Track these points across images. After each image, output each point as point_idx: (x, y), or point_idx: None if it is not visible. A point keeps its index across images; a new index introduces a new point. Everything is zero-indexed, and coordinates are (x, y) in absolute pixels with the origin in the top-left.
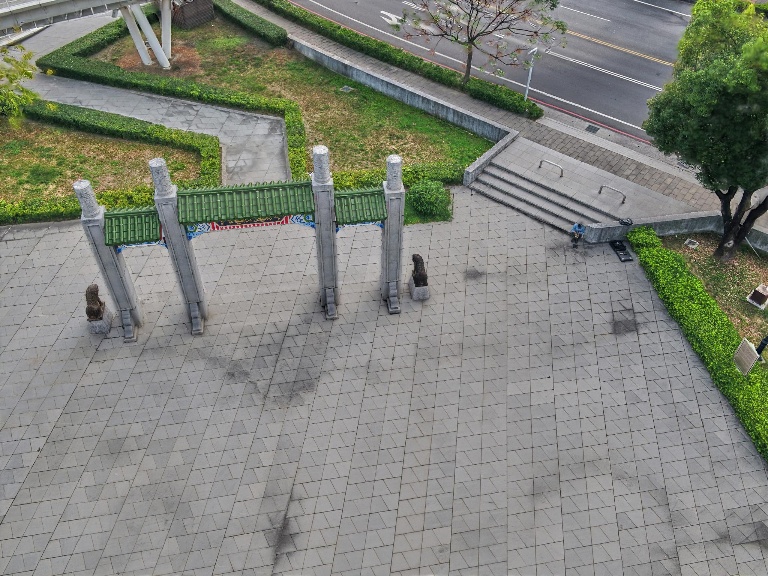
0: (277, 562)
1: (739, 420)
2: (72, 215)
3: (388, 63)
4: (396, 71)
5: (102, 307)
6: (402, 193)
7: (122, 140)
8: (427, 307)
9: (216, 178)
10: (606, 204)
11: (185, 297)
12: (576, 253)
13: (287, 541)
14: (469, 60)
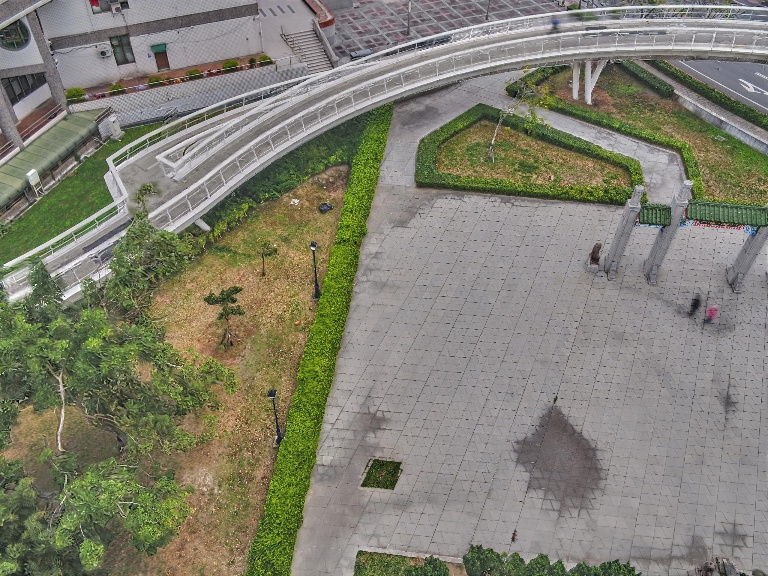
0: (727, 413)
1: None
2: (554, 197)
3: (753, 123)
4: (760, 131)
5: None
6: None
7: (571, 152)
8: None
9: None
10: None
11: (653, 261)
12: None
13: (731, 405)
14: None
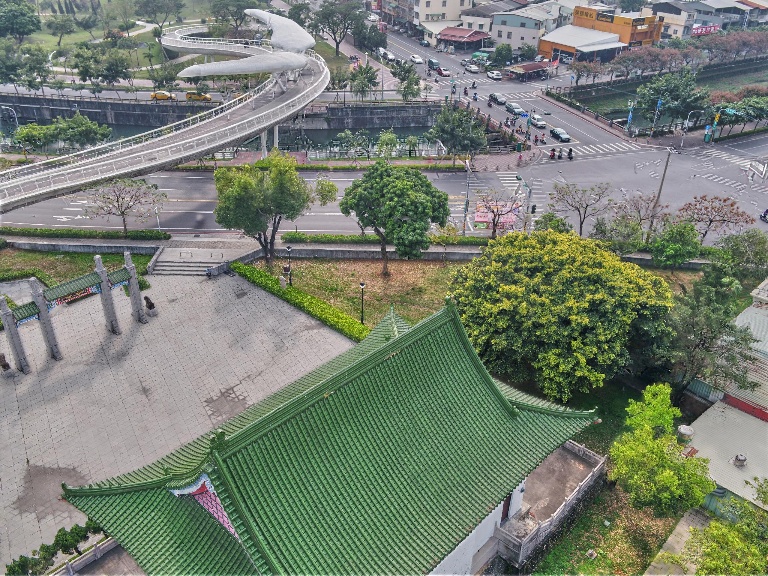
0: (148, 396)
1: (291, 304)
2: None
3: (77, 238)
4: (84, 240)
5: None
6: (134, 266)
7: None
8: (159, 317)
9: None
10: (216, 260)
11: (49, 344)
12: (212, 280)
13: (148, 391)
14: (124, 222)
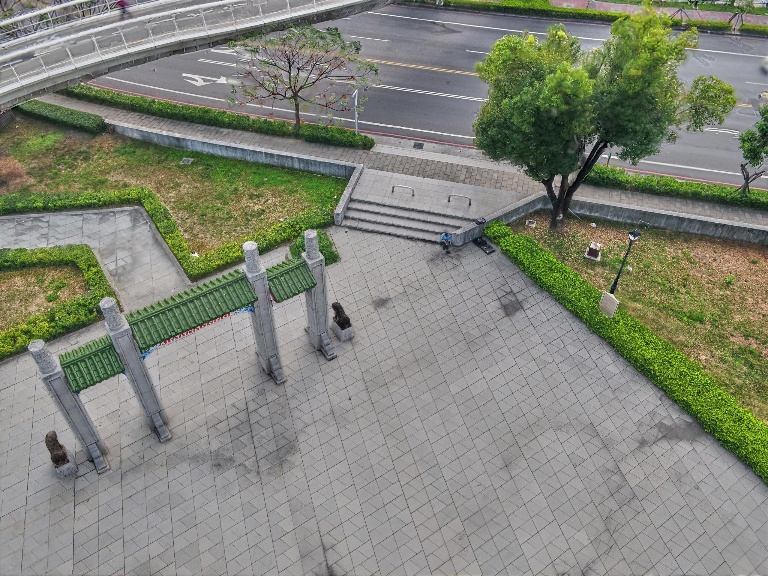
0: None
1: (618, 352)
2: None
3: (216, 126)
4: (227, 132)
5: (63, 450)
6: (322, 259)
7: None
8: (356, 344)
9: (107, 286)
10: (458, 210)
11: (146, 411)
12: (451, 258)
13: None
14: (297, 110)
